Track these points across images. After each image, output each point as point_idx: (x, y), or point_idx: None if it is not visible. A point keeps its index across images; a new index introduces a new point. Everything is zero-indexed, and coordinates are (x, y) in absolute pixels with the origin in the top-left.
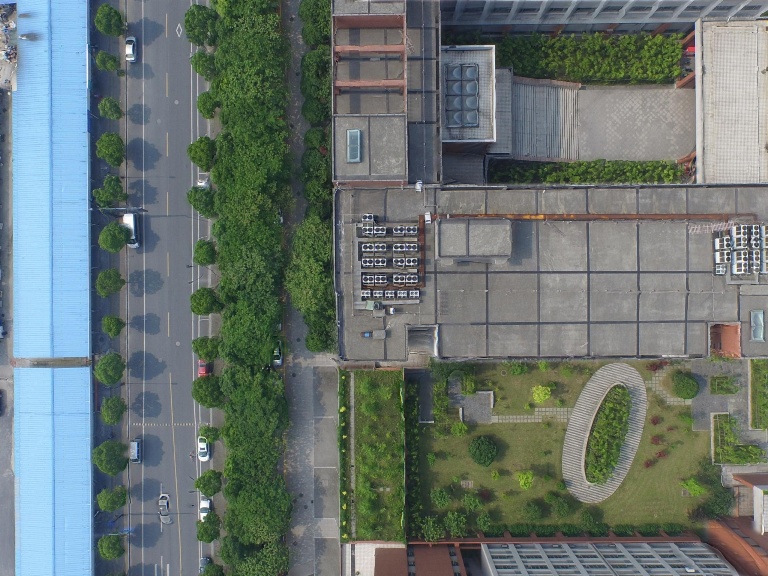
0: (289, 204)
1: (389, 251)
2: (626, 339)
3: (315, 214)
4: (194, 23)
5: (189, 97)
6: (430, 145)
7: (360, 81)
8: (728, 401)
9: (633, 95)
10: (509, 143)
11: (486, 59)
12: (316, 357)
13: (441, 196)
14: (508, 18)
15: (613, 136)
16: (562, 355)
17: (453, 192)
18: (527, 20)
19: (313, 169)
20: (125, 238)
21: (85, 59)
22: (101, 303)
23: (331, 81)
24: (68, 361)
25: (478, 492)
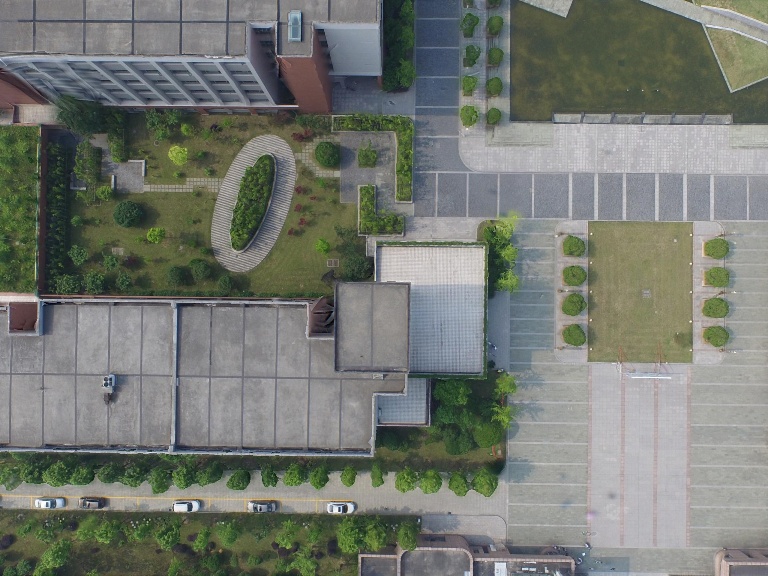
0: None
1: None
2: (169, 38)
3: None
4: None
5: None
6: None
7: None
8: (376, 174)
9: None
10: None
11: None
12: None
13: None
14: None
15: None
16: (107, 53)
17: None
18: None
19: None
20: None
21: None
22: None
23: None
24: None
25: (128, 259)
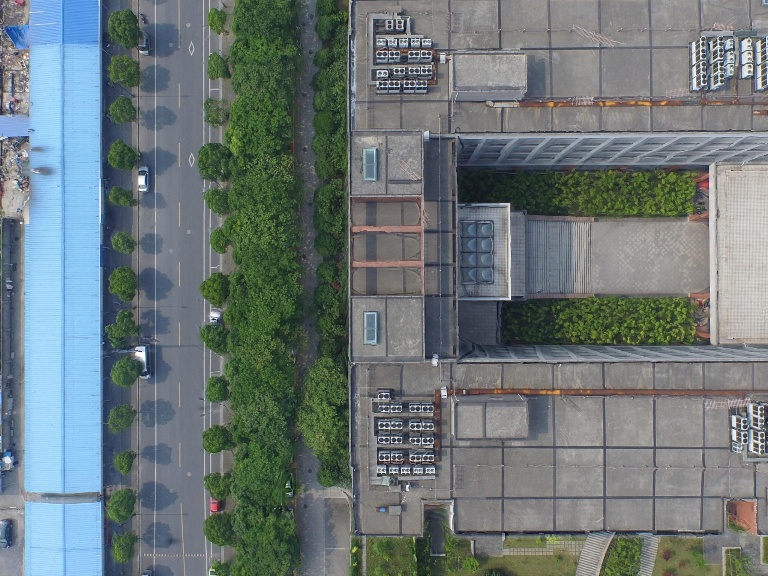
0: (302, 343)
1: (405, 426)
2: (642, 514)
3: (328, 351)
4: (208, 163)
5: (201, 227)
6: (446, 318)
7: (377, 262)
8: (740, 535)
9: (646, 228)
10: (523, 286)
11: (501, 215)
12: (327, 488)
13: (457, 370)
14: (522, 162)
15: (626, 269)
16: (578, 530)
17: (469, 365)
18: (541, 163)
19: (326, 306)
20: (137, 374)
21: (98, 193)
22: (112, 435)
23: (344, 217)
24: (79, 496)
25: None
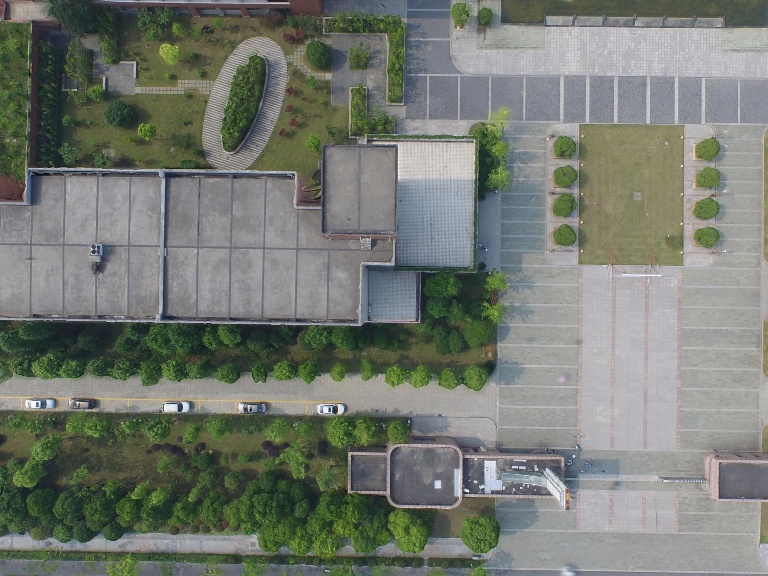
0: None
1: None
2: None
3: None
4: None
5: None
6: None
7: None
8: (367, 77)
9: None
10: None
11: None
12: None
13: None
14: None
15: None
16: None
17: None
18: None
19: None
20: None
21: None
22: None
23: None
24: None
25: (119, 160)
